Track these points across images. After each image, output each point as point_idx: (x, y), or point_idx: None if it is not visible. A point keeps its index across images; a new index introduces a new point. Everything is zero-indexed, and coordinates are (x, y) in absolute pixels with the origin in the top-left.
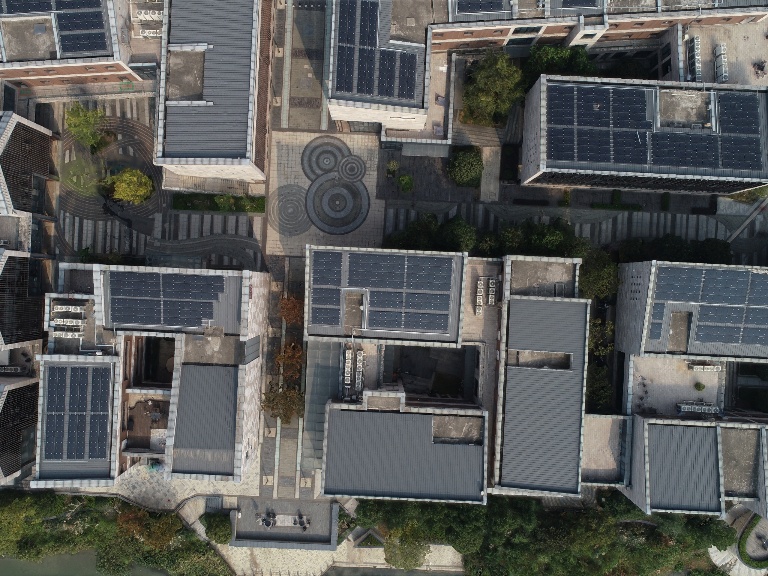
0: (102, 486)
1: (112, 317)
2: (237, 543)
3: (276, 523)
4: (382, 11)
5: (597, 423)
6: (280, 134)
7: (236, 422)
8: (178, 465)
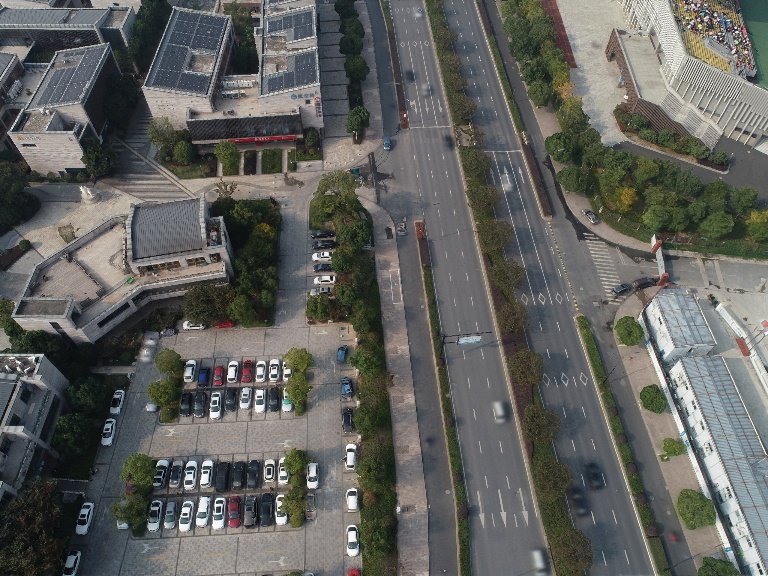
0: None
1: None
2: None
3: None
4: None
5: None
6: None
7: None
8: None
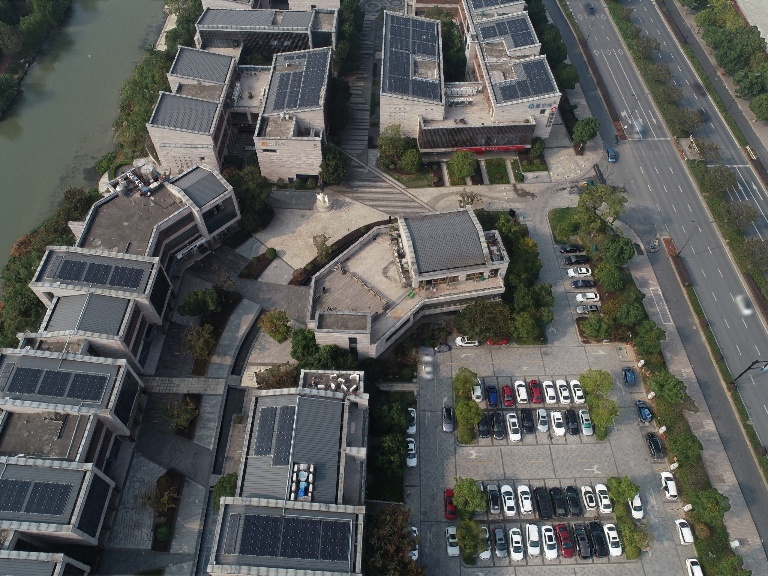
0: None
1: None
2: None
3: None
4: None
5: None
6: None
7: None
8: None
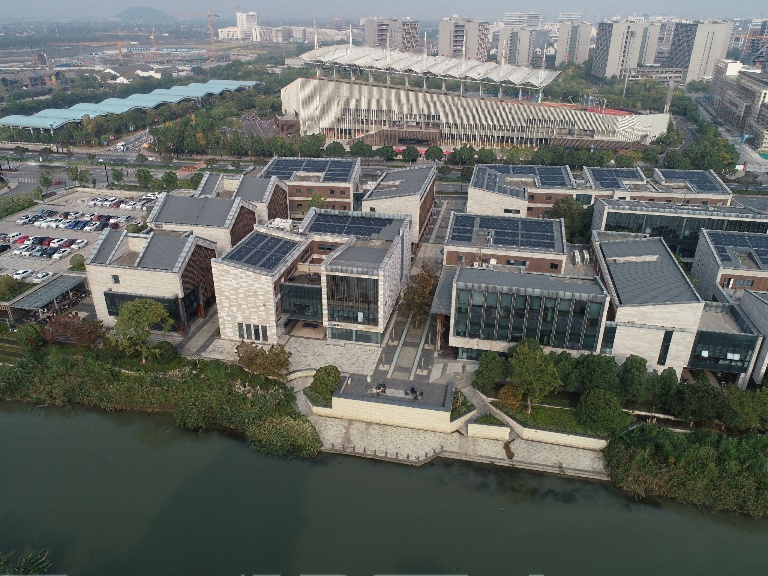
0: (263, 274)
1: (310, 229)
2: (341, 395)
3: (385, 393)
4: (499, 180)
5: None
6: None
7: (388, 251)
8: (333, 265)
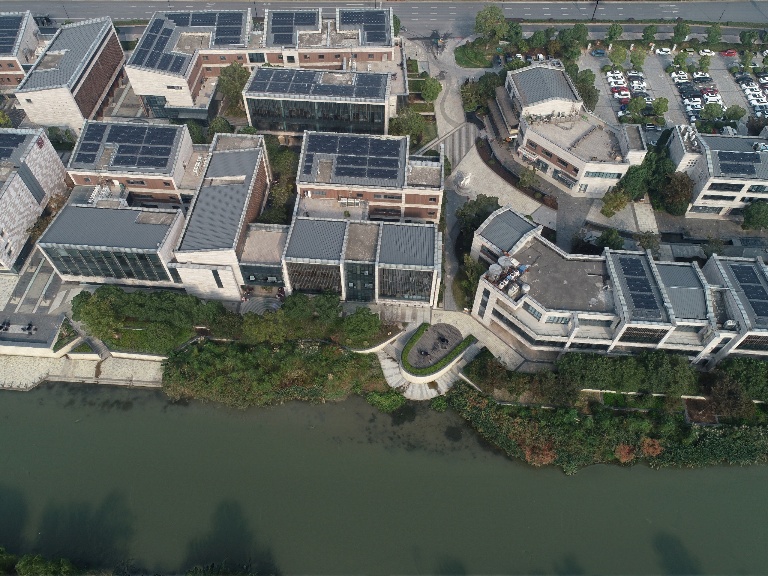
0: None
1: None
2: None
3: (8, 330)
4: (171, 41)
5: (270, 235)
6: (109, 118)
7: None
8: None
